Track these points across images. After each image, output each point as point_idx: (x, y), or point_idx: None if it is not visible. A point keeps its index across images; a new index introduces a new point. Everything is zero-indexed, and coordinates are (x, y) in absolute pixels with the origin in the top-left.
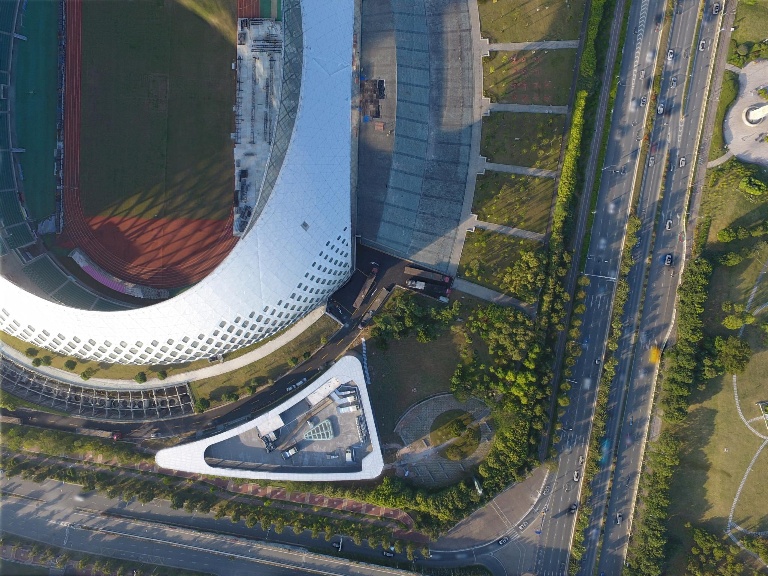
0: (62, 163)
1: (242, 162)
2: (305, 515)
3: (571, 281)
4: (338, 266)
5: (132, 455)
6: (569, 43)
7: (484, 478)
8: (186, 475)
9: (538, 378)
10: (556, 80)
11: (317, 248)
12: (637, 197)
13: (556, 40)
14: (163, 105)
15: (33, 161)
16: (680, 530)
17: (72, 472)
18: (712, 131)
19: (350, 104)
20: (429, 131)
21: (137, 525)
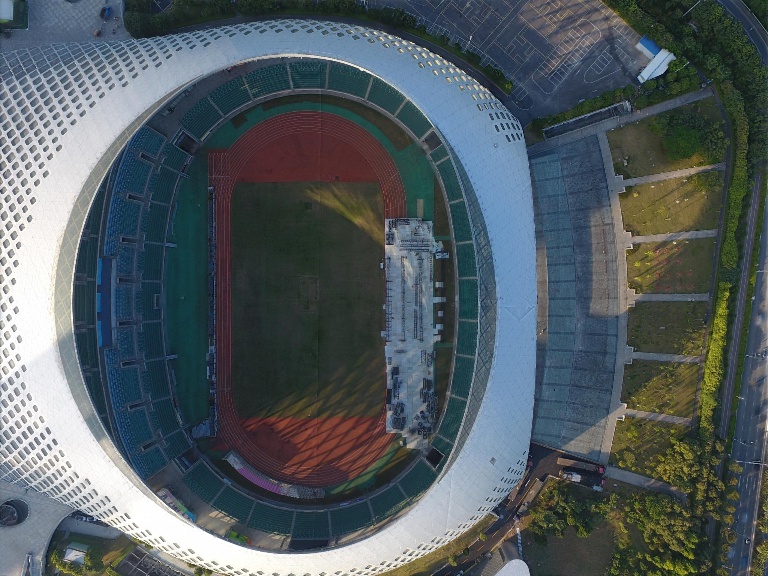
0: (215, 367)
1: (393, 359)
2: None
3: None
4: (513, 484)
5: None
6: (708, 232)
7: None
8: None
9: (696, 566)
10: (697, 268)
11: (500, 476)
12: None
13: (695, 230)
14: (314, 306)
15: (185, 366)
16: None
17: None
18: None
19: (535, 342)
20: (576, 323)
21: None
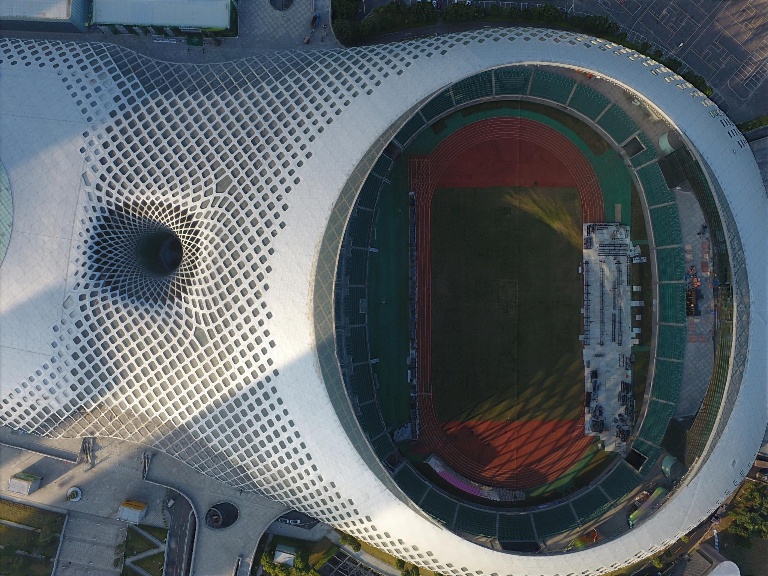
0: (417, 371)
1: (592, 363)
2: None
3: None
4: None
5: None
6: None
7: None
8: None
9: None
10: None
11: (733, 478)
12: None
13: None
14: (513, 310)
15: (387, 369)
16: None
17: None
18: None
19: None
20: None
21: None
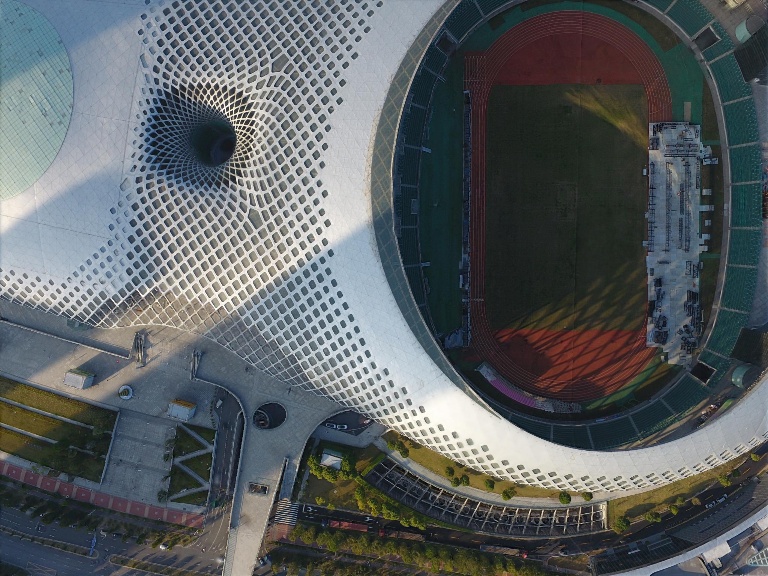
0: (469, 276)
1: (656, 270)
2: None
3: None
4: None
5: None
6: None
7: None
8: None
9: None
10: None
11: None
12: None
13: None
14: (572, 214)
15: (438, 274)
16: None
17: None
18: None
19: None
20: None
21: None
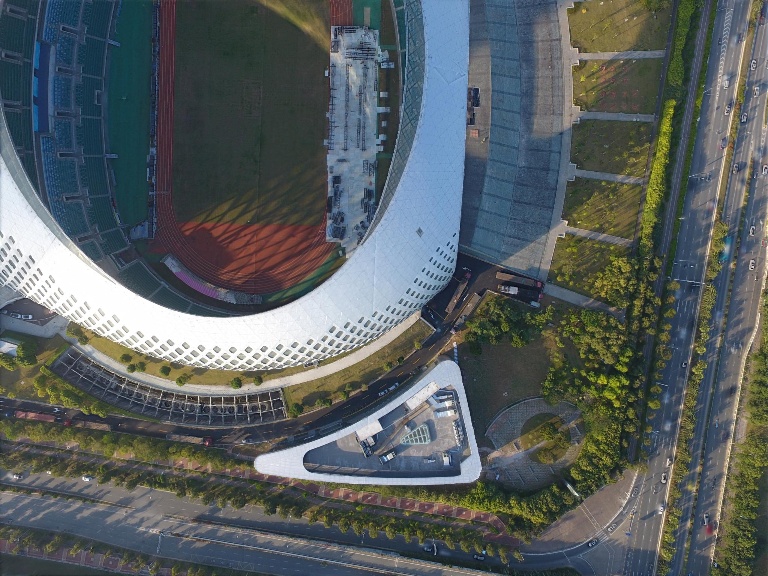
0: (155, 169)
1: (335, 168)
2: (396, 519)
3: (658, 286)
4: (444, 272)
5: (226, 461)
6: (656, 53)
7: (577, 481)
8: (277, 481)
9: None
10: (643, 89)
11: (428, 254)
12: (722, 203)
13: (643, 50)
14: (256, 111)
15: (125, 167)
16: (766, 530)
17: (162, 479)
18: None
19: None
20: (520, 138)
21: (228, 531)
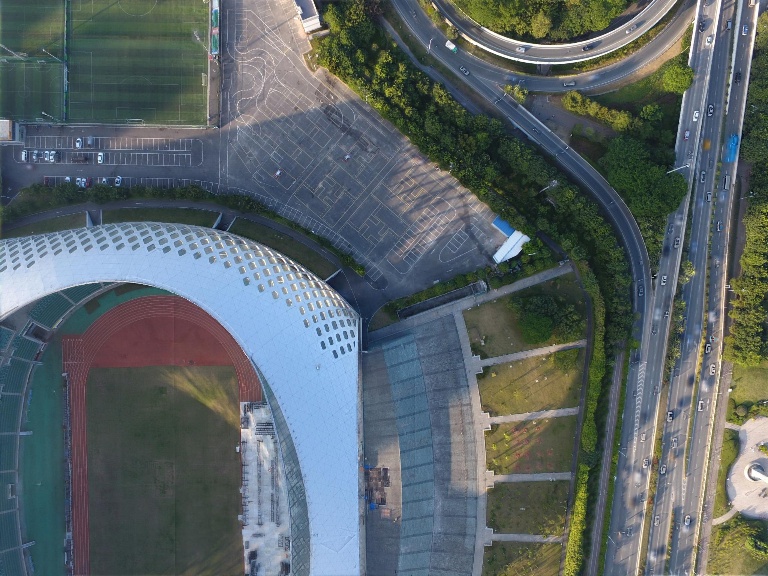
0: (72, 554)
1: (251, 543)
2: None
3: None
4: None
5: None
6: (569, 410)
7: None
8: None
9: None
10: (558, 447)
11: None
12: (644, 558)
13: (556, 408)
14: (170, 491)
15: (43, 552)
16: None
17: None
18: (715, 489)
19: (358, 569)
20: (435, 505)
21: None
